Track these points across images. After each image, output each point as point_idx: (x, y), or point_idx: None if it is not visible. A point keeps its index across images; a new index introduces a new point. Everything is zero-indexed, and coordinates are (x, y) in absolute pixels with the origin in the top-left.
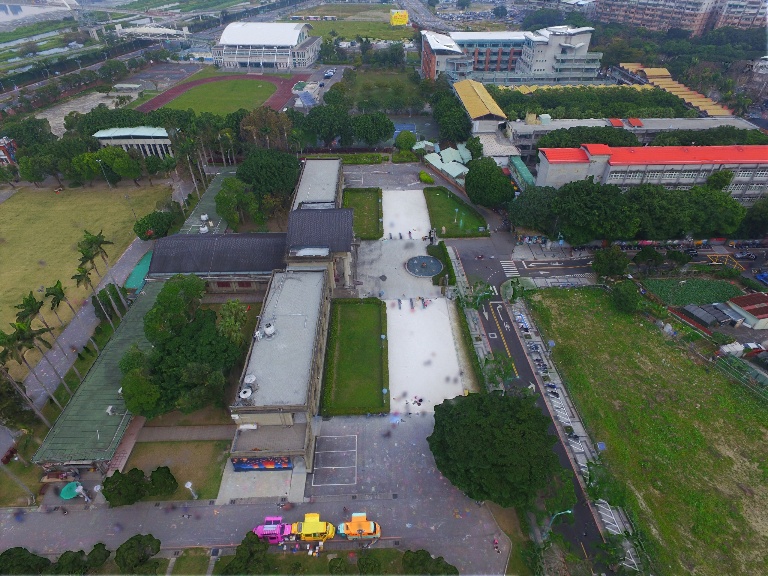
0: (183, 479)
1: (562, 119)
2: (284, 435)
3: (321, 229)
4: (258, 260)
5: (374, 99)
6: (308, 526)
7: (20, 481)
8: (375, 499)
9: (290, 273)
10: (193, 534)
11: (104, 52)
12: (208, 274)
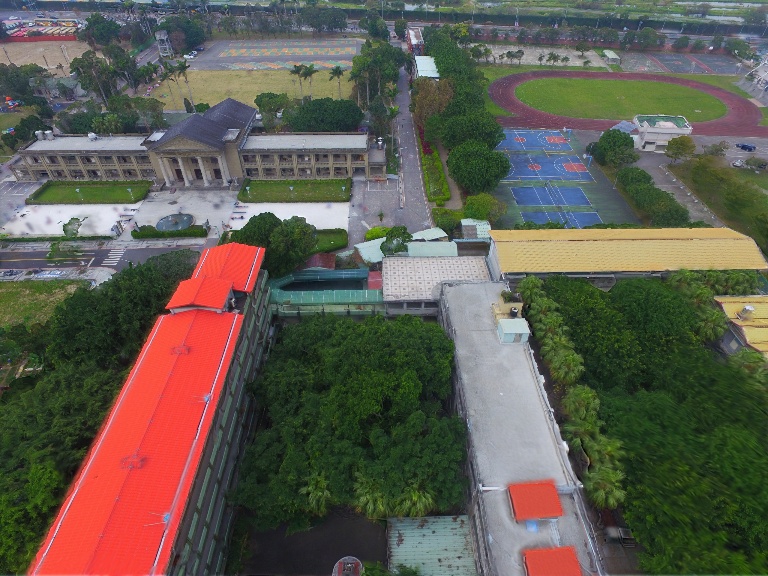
0: None
1: (539, 372)
2: None
3: None
4: None
5: (637, 172)
6: None
7: None
8: None
9: None
10: None
11: (685, 23)
12: None
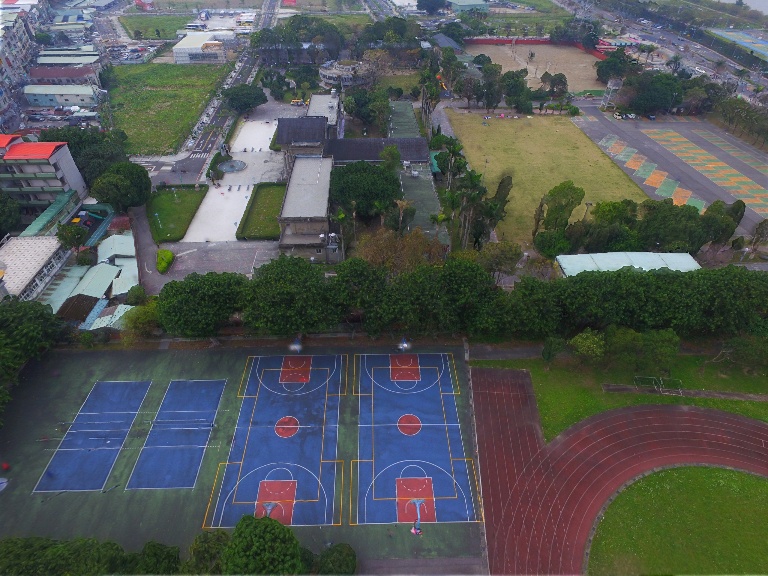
0: None
1: None
2: None
3: None
4: None
5: (103, 554)
6: None
7: None
8: None
9: None
10: None
11: None
12: None
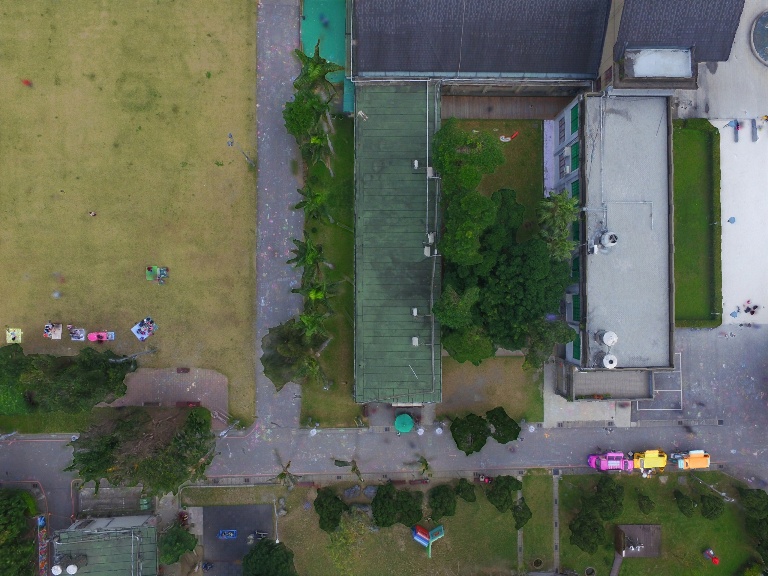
0: (503, 401)
1: None
2: (624, 376)
3: (688, 5)
4: (539, 48)
5: None
6: (649, 462)
7: (333, 400)
8: (701, 425)
9: (610, 98)
10: (531, 457)
11: None
12: (457, 76)
